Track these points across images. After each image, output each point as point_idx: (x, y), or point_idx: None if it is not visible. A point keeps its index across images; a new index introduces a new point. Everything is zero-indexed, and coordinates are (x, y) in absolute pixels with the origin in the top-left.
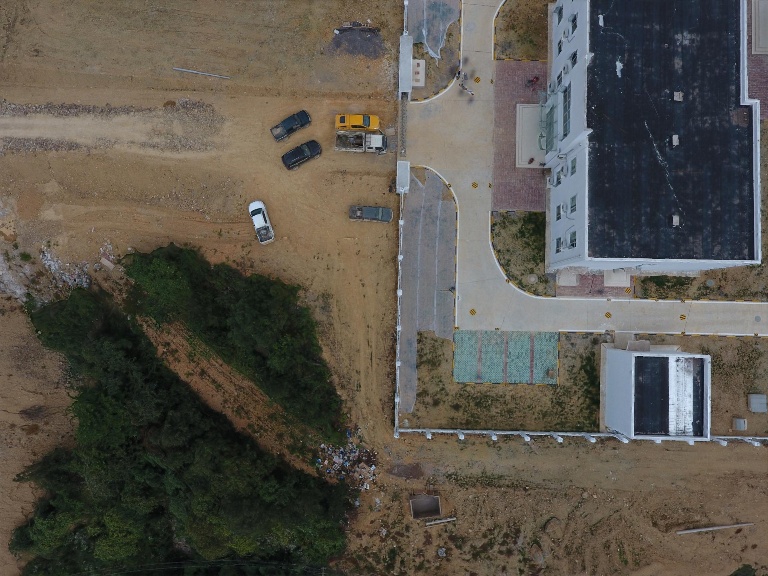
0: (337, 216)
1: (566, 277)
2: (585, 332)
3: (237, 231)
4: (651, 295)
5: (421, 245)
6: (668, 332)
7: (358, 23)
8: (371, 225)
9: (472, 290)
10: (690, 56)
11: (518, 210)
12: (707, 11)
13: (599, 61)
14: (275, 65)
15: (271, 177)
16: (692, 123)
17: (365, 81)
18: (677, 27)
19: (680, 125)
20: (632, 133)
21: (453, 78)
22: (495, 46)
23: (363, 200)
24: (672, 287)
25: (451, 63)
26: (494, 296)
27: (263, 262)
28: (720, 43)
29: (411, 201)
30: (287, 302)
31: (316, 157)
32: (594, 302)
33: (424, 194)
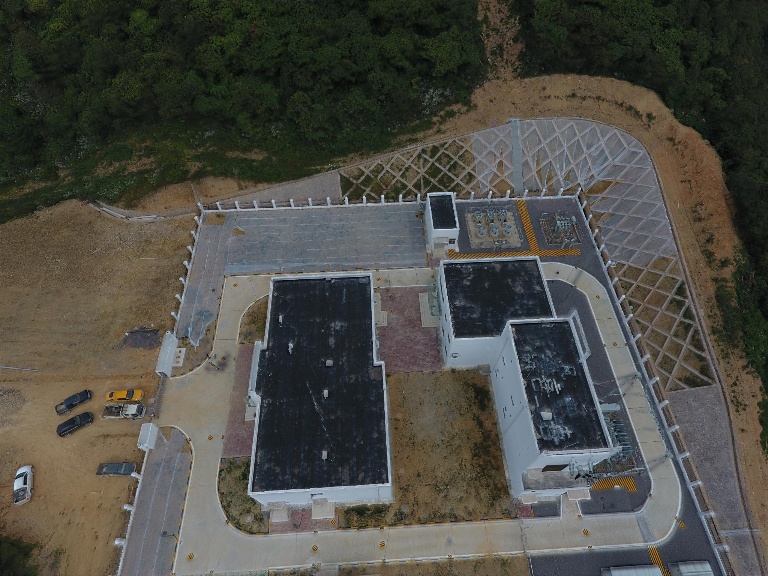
0: (90, 473)
1: (278, 513)
2: (293, 567)
3: (3, 494)
4: (353, 524)
5: (155, 494)
6: (369, 561)
7: (143, 327)
8: (117, 479)
9: (194, 533)
10: (340, 336)
11: (243, 456)
12: (351, 309)
13: (277, 344)
14: (75, 359)
15: (47, 444)
16: (341, 380)
17: (140, 365)
18: (331, 319)
19: (332, 383)
20: (297, 391)
21: (206, 359)
22: (239, 335)
23: (116, 458)
24: (371, 515)
25: (206, 349)
26: (213, 537)
27: (15, 522)
28: (360, 327)
29: (155, 455)
30: (17, 560)
31: (87, 425)
32: (303, 536)
33: (167, 448)
